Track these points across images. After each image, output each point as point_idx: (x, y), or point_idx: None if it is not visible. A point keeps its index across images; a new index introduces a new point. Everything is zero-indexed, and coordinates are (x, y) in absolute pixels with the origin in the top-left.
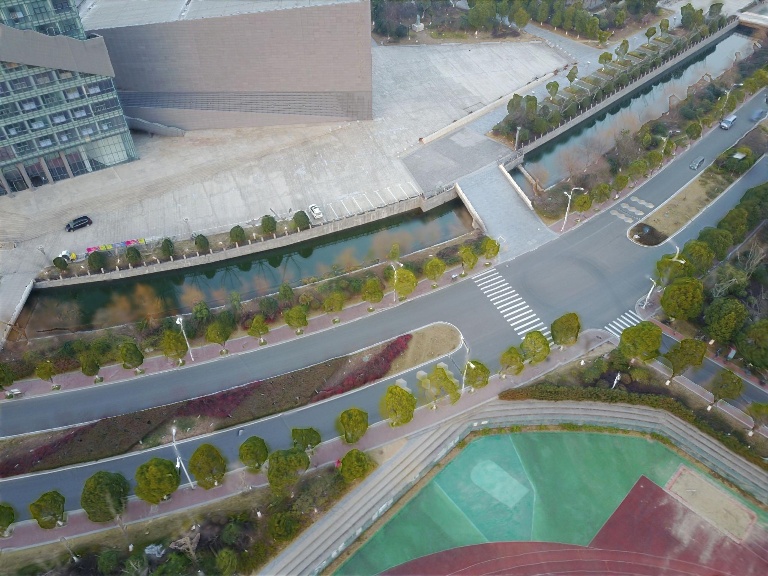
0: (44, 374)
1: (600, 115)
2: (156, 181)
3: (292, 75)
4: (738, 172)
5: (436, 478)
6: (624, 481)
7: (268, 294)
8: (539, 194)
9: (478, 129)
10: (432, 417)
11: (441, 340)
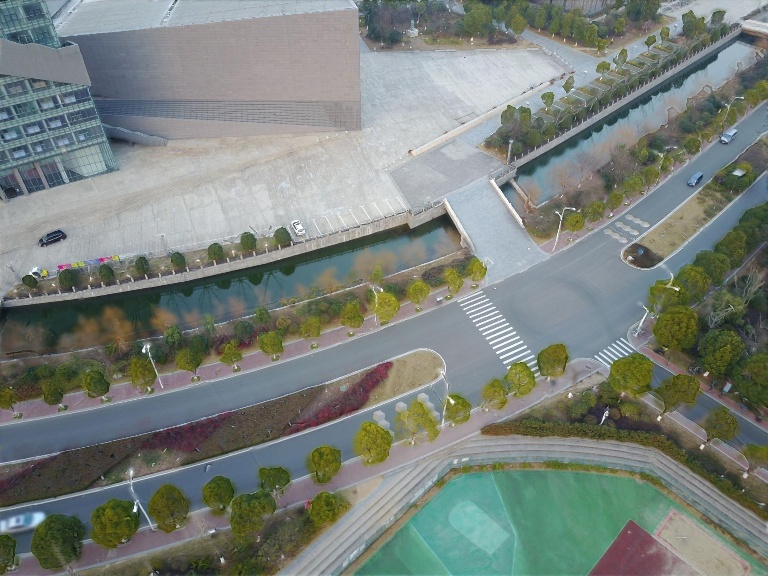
0: (4, 403)
1: (597, 126)
2: (135, 193)
3: (278, 84)
4: (738, 190)
5: (412, 520)
6: (610, 526)
7: (245, 316)
8: (531, 211)
9: (470, 141)
10: (410, 453)
11: (423, 369)
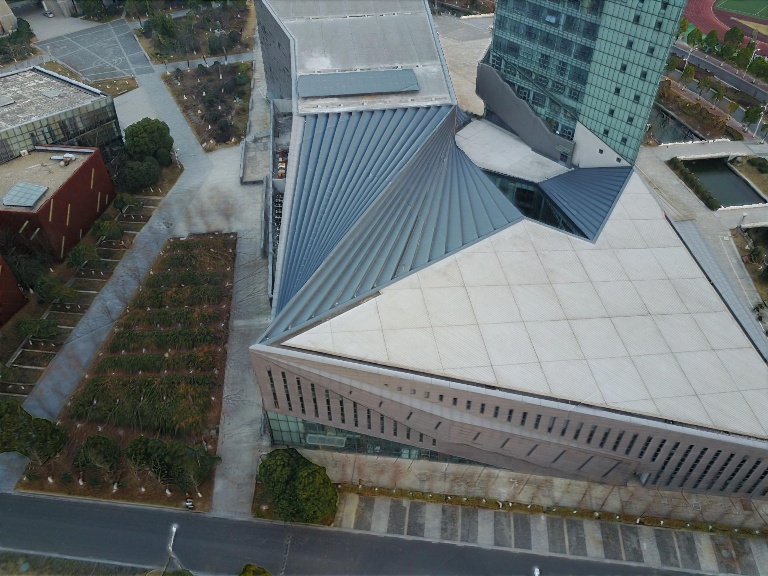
0: None
1: None
2: None
3: None
4: None
5: None
6: None
7: None
8: None
9: None
10: None
11: None
